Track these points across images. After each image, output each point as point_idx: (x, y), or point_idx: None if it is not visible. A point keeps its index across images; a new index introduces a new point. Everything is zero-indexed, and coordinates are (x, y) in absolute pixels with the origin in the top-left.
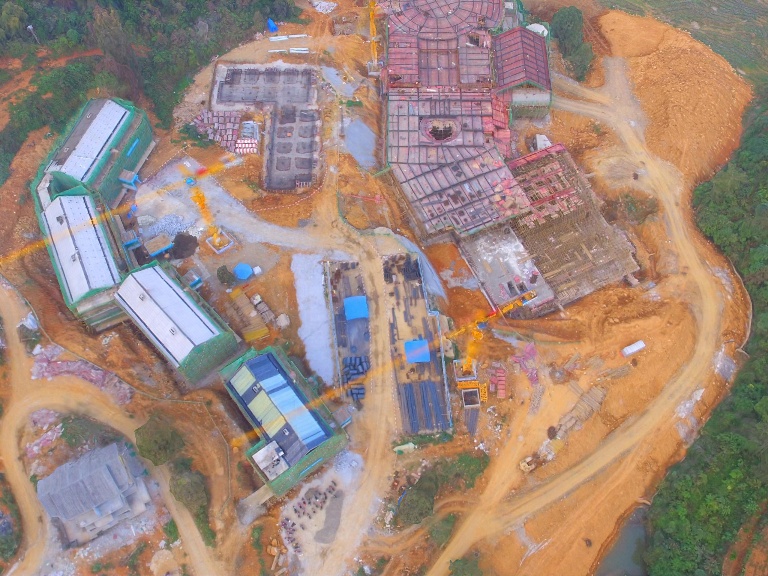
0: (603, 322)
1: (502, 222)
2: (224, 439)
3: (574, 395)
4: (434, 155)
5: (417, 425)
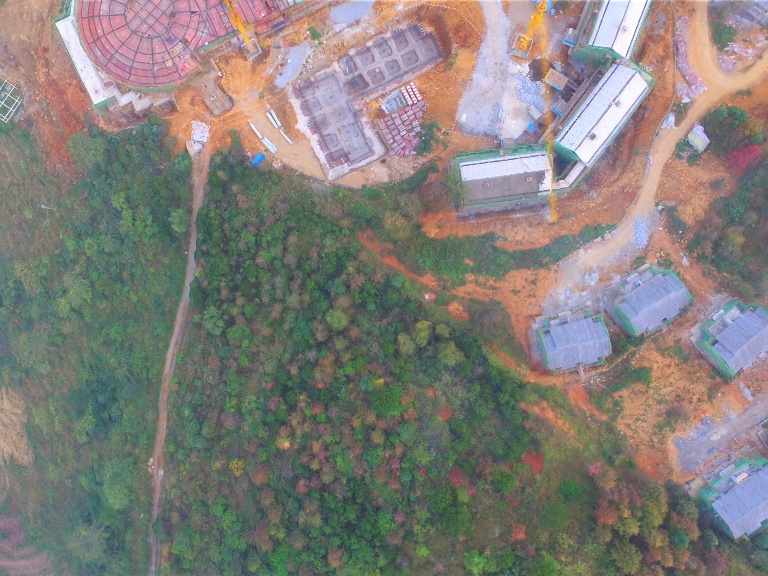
0: None
1: None
2: None
3: None
4: None
5: None
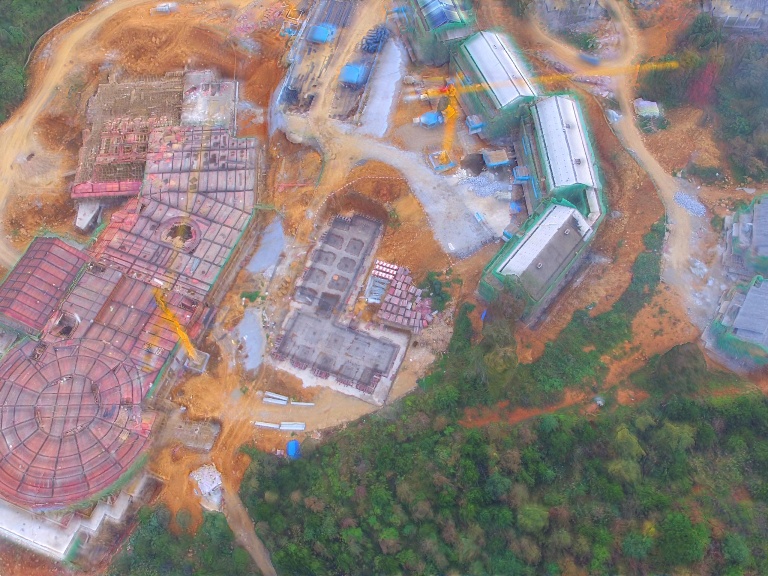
0: (165, 43)
1: (187, 127)
2: (477, 21)
3: (224, 1)
4: (205, 207)
5: (342, 4)
